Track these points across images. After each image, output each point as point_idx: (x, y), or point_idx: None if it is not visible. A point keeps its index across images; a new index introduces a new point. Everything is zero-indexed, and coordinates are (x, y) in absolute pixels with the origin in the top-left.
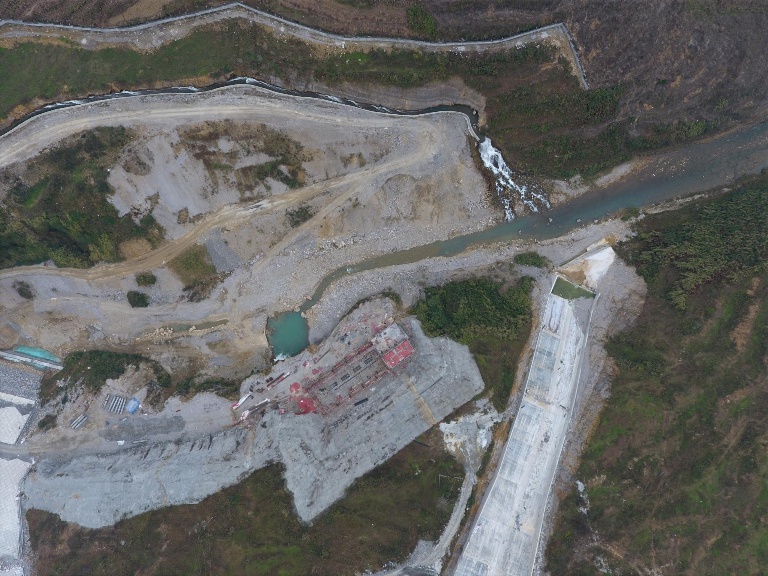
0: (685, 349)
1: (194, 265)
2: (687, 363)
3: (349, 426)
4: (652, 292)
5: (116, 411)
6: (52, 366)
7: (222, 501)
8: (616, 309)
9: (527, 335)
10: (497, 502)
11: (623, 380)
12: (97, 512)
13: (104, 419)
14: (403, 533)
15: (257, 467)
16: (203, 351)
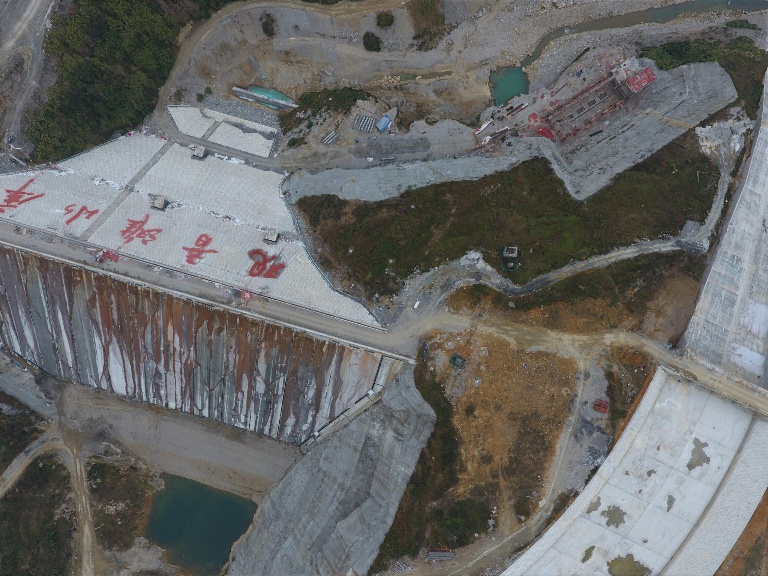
0: None
1: (429, 10)
2: None
3: (590, 149)
4: None
5: (366, 130)
6: (288, 104)
7: (499, 180)
8: None
9: (767, 63)
10: (744, 207)
11: None
12: (379, 188)
13: (353, 137)
14: (672, 214)
15: (524, 160)
16: (430, 98)
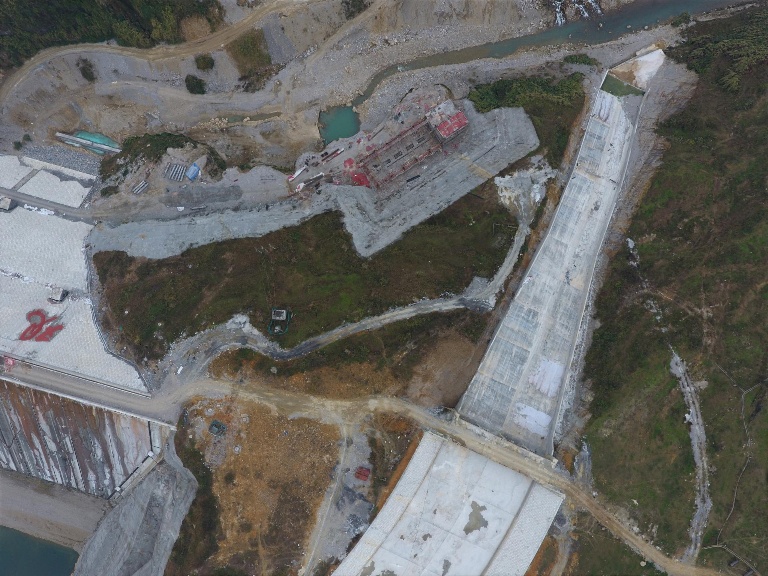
0: (737, 123)
1: (251, 51)
2: (739, 137)
3: (402, 196)
4: (704, 80)
5: (176, 178)
6: (112, 149)
7: (284, 237)
8: (666, 100)
9: (580, 106)
10: (548, 258)
11: (674, 151)
12: (164, 246)
13: (164, 186)
14: (459, 270)
15: (316, 213)
16: (257, 140)
